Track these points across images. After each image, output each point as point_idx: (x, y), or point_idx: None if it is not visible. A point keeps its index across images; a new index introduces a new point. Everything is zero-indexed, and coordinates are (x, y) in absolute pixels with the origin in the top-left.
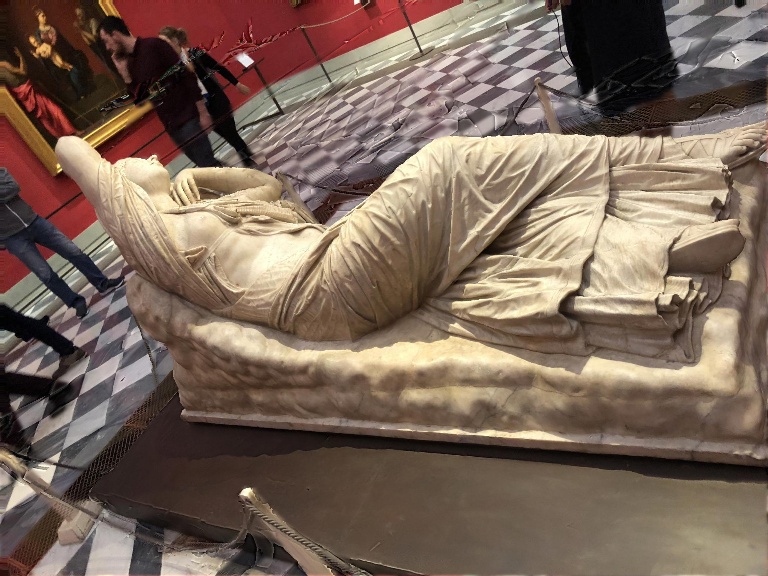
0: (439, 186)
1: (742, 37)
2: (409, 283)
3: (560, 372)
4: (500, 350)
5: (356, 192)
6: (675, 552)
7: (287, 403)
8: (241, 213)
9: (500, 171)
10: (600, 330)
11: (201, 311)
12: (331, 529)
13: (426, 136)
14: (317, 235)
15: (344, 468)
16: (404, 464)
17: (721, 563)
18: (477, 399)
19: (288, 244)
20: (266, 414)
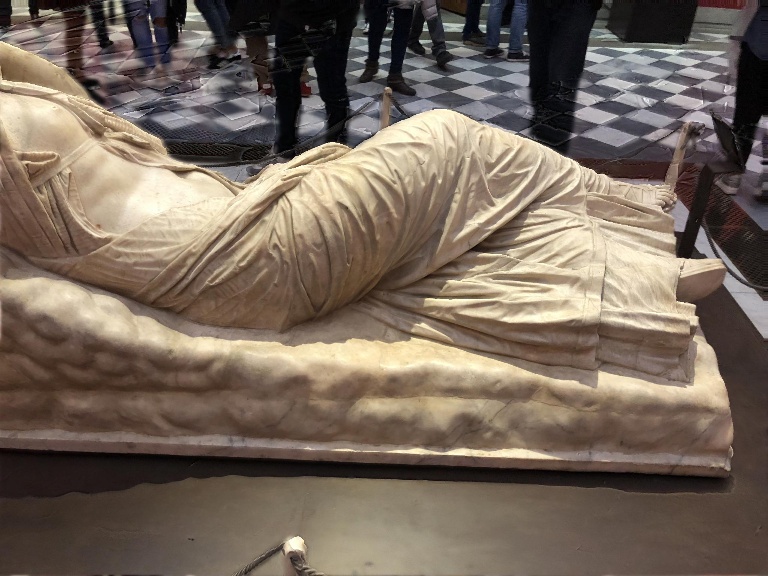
0: (450, 162)
1: (484, 117)
2: (379, 268)
3: (574, 385)
4: (491, 358)
5: None
6: (691, 563)
7: (141, 413)
8: None
9: (508, 164)
10: (612, 345)
11: (11, 256)
12: None
13: (217, 108)
14: (219, 183)
15: (243, 504)
16: (338, 494)
17: (735, 568)
18: (461, 412)
19: (184, 185)
20: (78, 430)
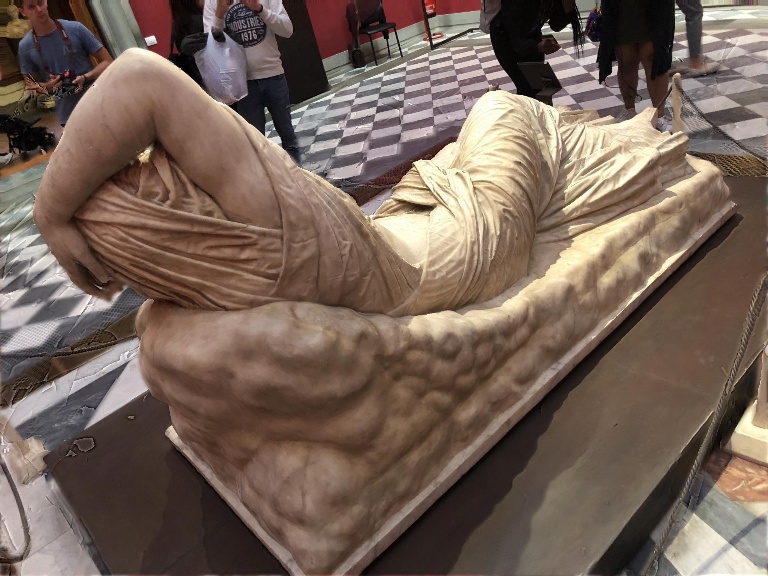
0: None
1: None
2: None
3: (669, 200)
4: (621, 217)
5: (94, 346)
6: None
7: (505, 387)
8: None
9: None
10: None
11: None
12: (687, 405)
13: None
14: None
15: (603, 393)
16: (629, 350)
17: None
18: (639, 254)
19: (402, 218)
20: (470, 442)
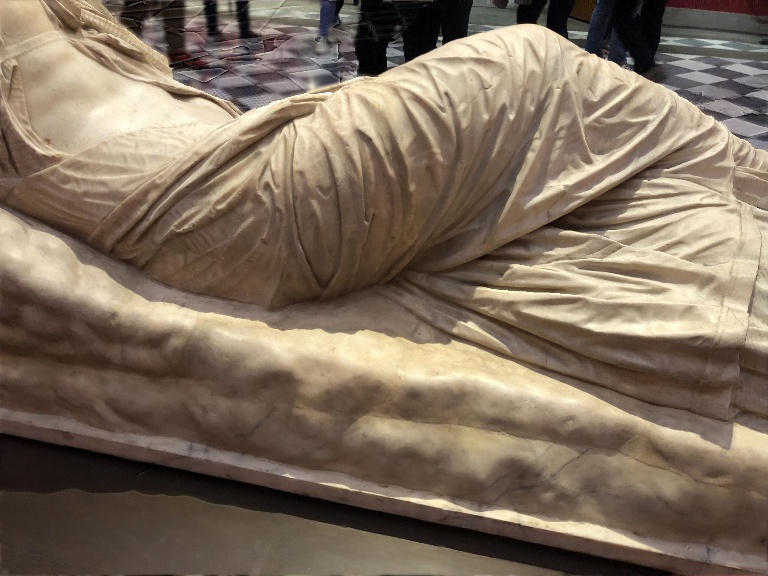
0: (530, 92)
1: None
2: (414, 235)
3: (692, 439)
4: (563, 382)
5: None
6: None
7: (79, 394)
8: (81, 20)
9: (618, 107)
10: (760, 385)
11: None
12: None
13: (293, 78)
14: (224, 113)
15: (187, 540)
16: (319, 547)
17: None
18: (509, 456)
19: (173, 105)
20: (9, 406)
